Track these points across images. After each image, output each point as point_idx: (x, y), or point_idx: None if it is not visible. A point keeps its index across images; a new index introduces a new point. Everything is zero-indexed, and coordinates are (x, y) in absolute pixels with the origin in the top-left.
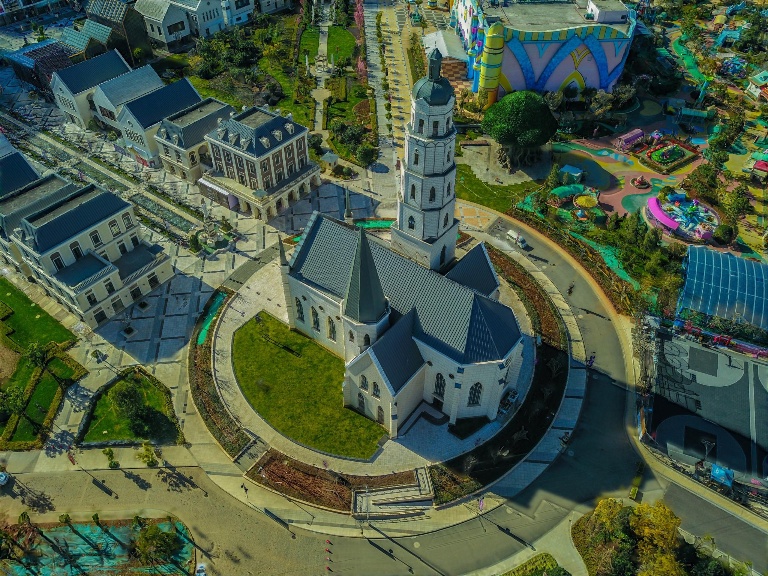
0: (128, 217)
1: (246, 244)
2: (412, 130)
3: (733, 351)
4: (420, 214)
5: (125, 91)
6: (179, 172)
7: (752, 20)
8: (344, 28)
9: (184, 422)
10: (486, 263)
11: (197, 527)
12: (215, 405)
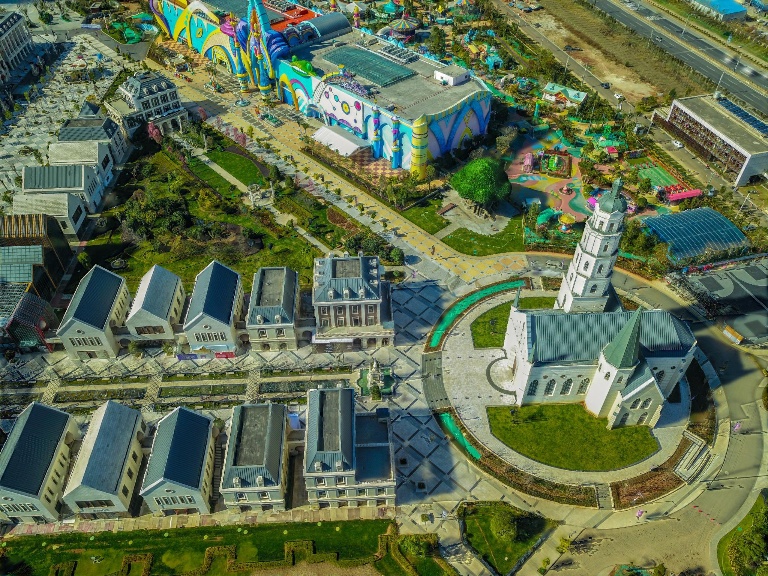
0: None
1: (403, 370)
2: (602, 232)
3: (715, 270)
4: (604, 281)
5: (160, 300)
6: (277, 346)
7: (493, 44)
8: (221, 150)
9: (540, 512)
10: (614, 290)
11: (633, 559)
12: (547, 486)
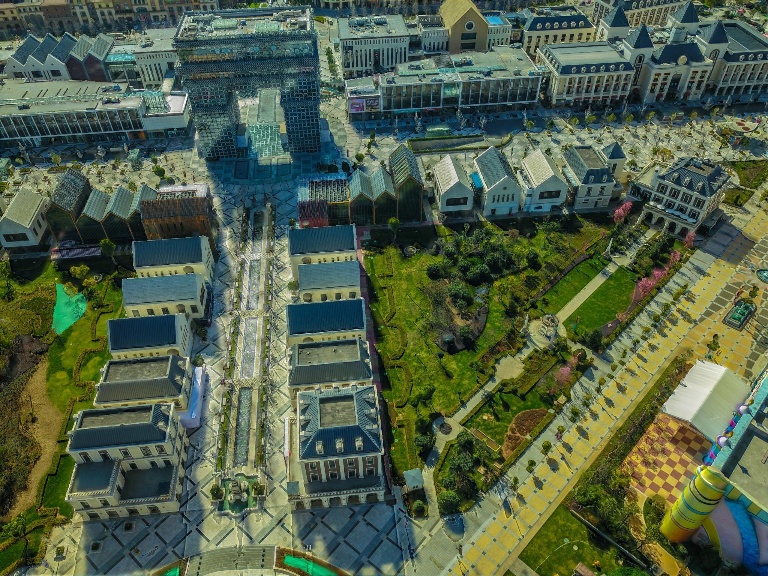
0: (162, 447)
1: (254, 523)
2: None
3: None
4: None
5: (319, 278)
6: None
7: None
8: (634, 279)
9: None
10: None
11: None
12: None
